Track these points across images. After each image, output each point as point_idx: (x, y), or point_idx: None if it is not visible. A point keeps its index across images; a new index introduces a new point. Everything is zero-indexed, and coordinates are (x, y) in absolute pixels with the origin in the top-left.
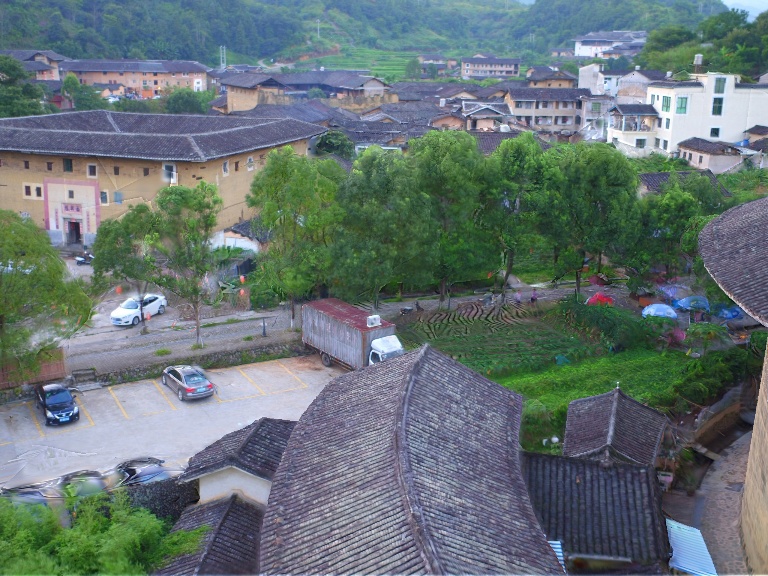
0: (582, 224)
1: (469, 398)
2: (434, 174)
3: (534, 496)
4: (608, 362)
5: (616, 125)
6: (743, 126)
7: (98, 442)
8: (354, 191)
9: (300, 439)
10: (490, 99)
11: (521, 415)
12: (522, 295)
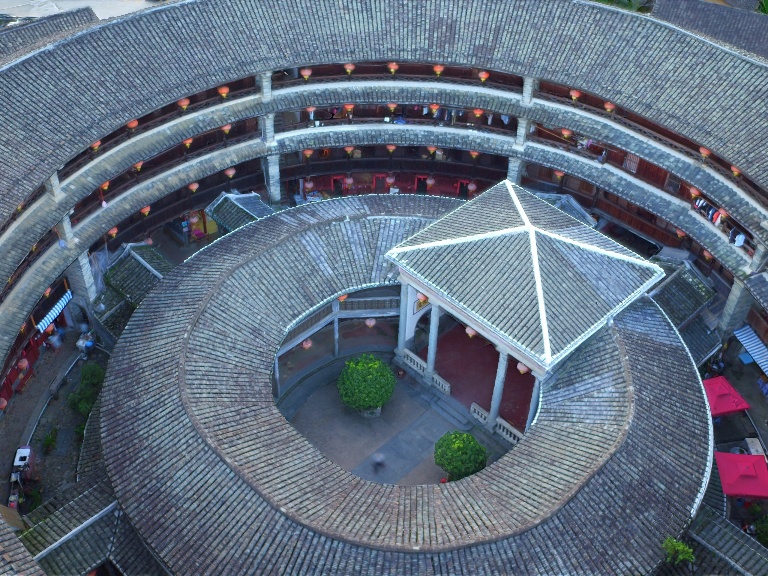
0: None
1: None
2: None
3: None
4: None
5: None
6: None
7: (80, 6)
8: None
9: None
10: None
11: None
12: None
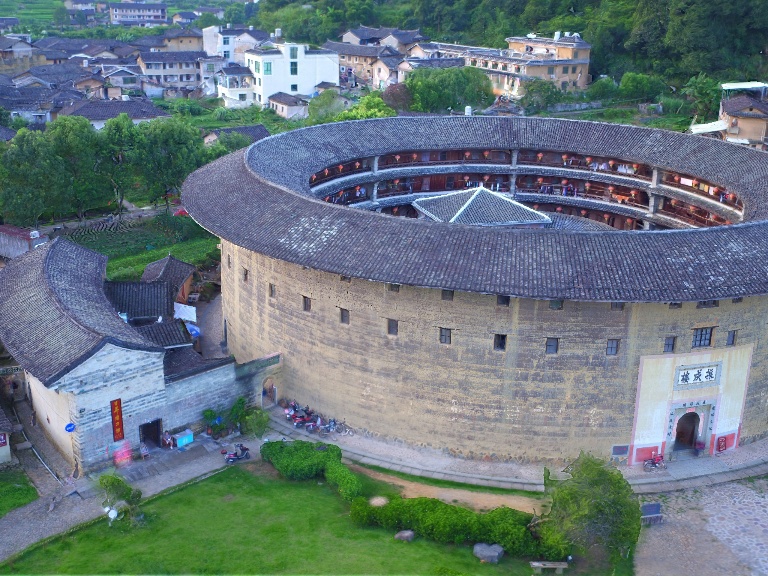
0: (162, 168)
1: (80, 257)
2: (64, 144)
3: (116, 298)
4: (177, 246)
5: (223, 83)
6: (314, 82)
7: None
8: (13, 158)
9: (0, 280)
10: (125, 62)
11: (121, 274)
12: (134, 214)
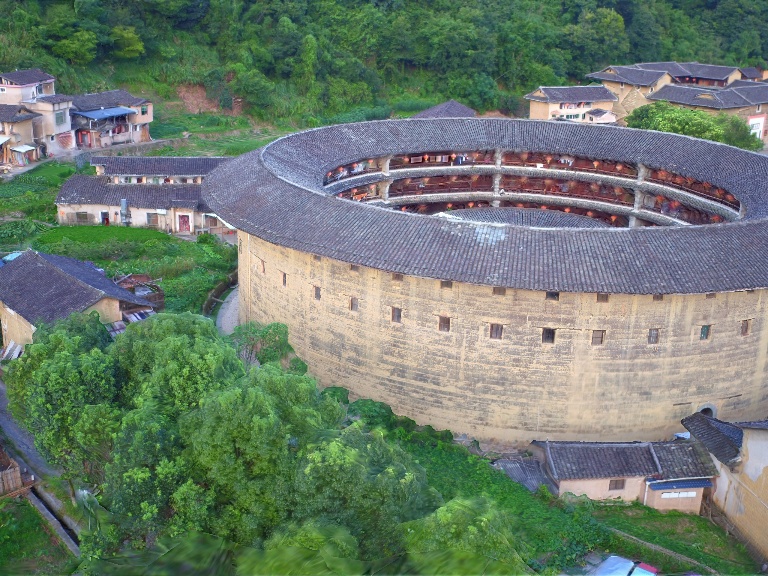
0: None
1: None
2: None
3: None
4: None
5: None
6: None
7: None
8: None
9: None
10: None
11: None
12: None
